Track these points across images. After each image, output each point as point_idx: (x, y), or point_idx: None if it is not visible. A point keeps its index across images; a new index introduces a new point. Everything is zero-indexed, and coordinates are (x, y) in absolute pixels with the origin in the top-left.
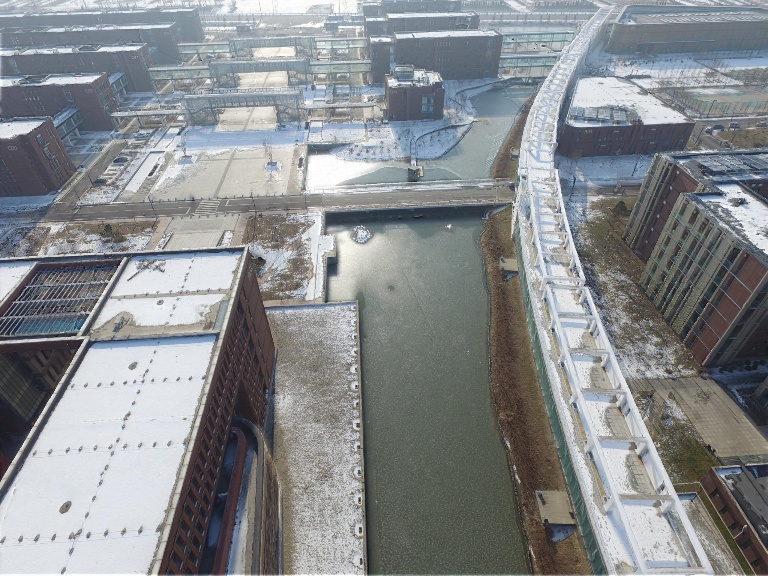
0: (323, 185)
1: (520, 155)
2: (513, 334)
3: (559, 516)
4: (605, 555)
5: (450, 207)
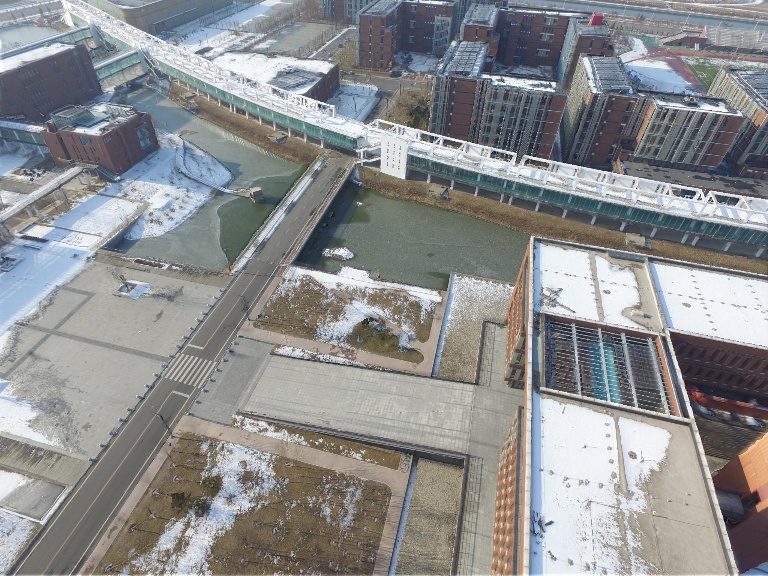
0: (214, 260)
1: (325, 127)
2: (507, 213)
3: (641, 240)
4: (690, 216)
5: (337, 192)
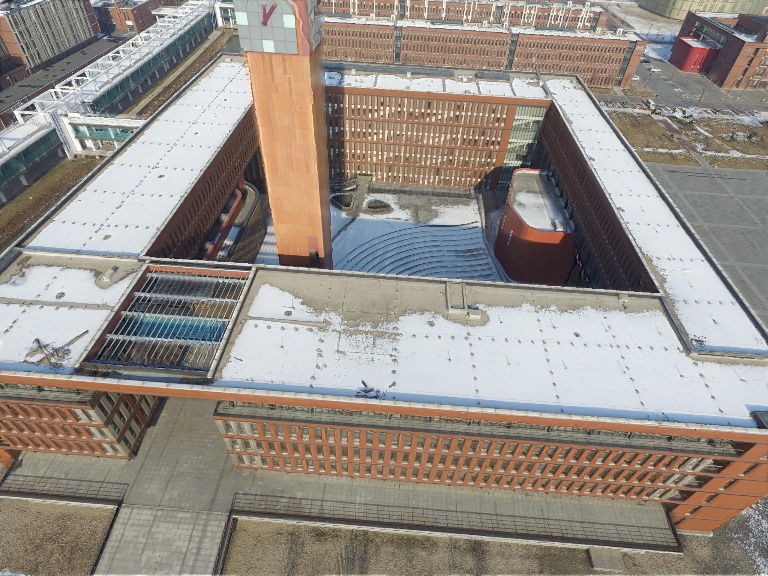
0: None
1: None
2: None
3: None
4: None
5: None
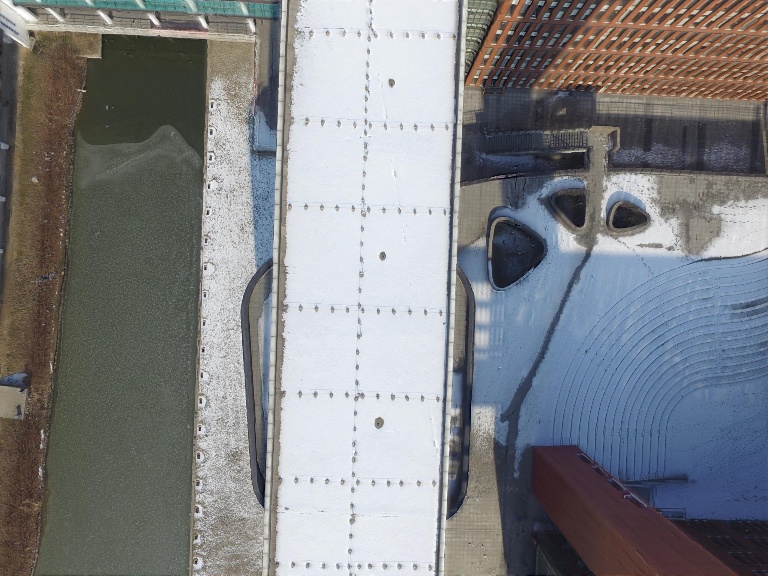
0: None
1: None
2: None
3: (8, 394)
4: None
5: None
